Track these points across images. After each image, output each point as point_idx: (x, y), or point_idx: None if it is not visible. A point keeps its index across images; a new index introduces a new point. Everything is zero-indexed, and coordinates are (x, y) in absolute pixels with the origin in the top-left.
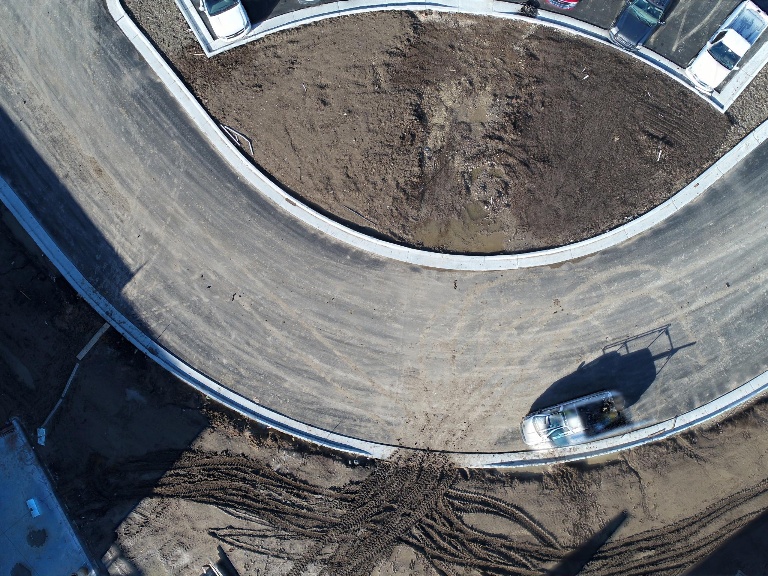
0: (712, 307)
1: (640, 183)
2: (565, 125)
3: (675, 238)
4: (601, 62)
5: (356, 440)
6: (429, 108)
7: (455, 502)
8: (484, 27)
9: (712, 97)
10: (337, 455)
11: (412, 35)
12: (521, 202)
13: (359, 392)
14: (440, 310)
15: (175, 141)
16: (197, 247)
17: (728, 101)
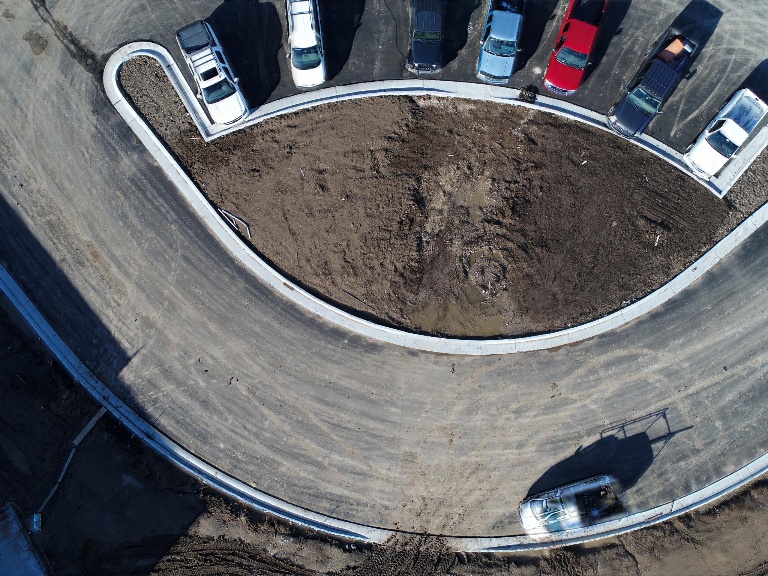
0: (709, 391)
1: (638, 268)
2: (563, 210)
3: (673, 322)
4: (599, 148)
5: (353, 524)
6: (427, 193)
7: None
8: (482, 112)
9: (710, 182)
10: (334, 539)
11: (410, 120)
12: (519, 286)
13: (356, 476)
14: (438, 394)
15: (172, 225)
16: (194, 331)
17: (726, 186)
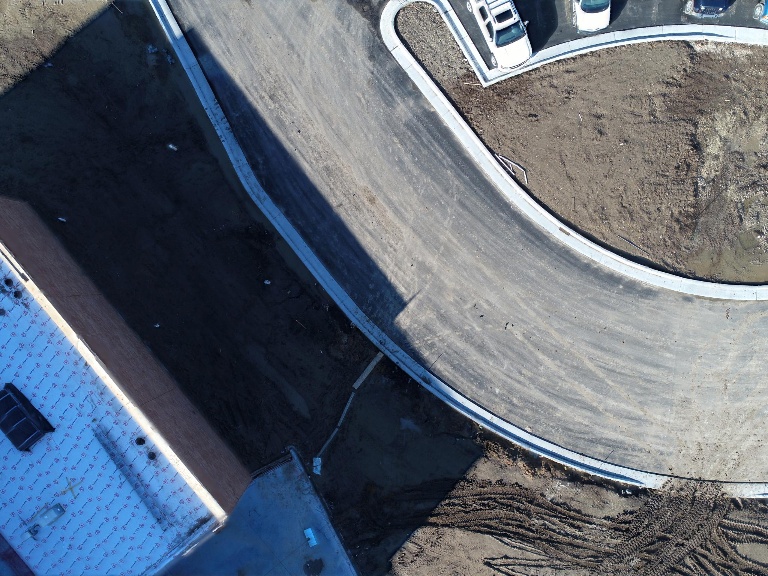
0: None
1: None
2: None
3: None
4: None
5: (628, 469)
6: (703, 138)
7: (729, 532)
8: (759, 57)
9: None
10: (609, 484)
11: (688, 65)
12: None
13: (631, 421)
14: (712, 339)
15: (448, 170)
16: (470, 276)
17: None
